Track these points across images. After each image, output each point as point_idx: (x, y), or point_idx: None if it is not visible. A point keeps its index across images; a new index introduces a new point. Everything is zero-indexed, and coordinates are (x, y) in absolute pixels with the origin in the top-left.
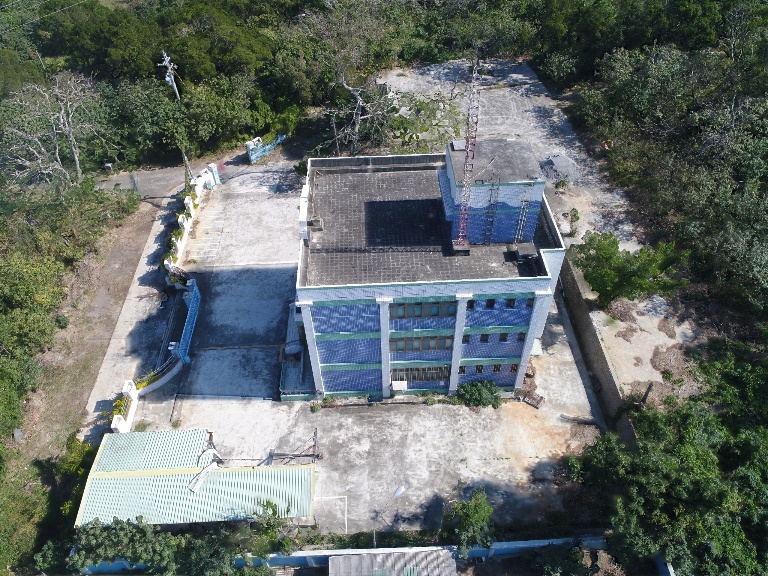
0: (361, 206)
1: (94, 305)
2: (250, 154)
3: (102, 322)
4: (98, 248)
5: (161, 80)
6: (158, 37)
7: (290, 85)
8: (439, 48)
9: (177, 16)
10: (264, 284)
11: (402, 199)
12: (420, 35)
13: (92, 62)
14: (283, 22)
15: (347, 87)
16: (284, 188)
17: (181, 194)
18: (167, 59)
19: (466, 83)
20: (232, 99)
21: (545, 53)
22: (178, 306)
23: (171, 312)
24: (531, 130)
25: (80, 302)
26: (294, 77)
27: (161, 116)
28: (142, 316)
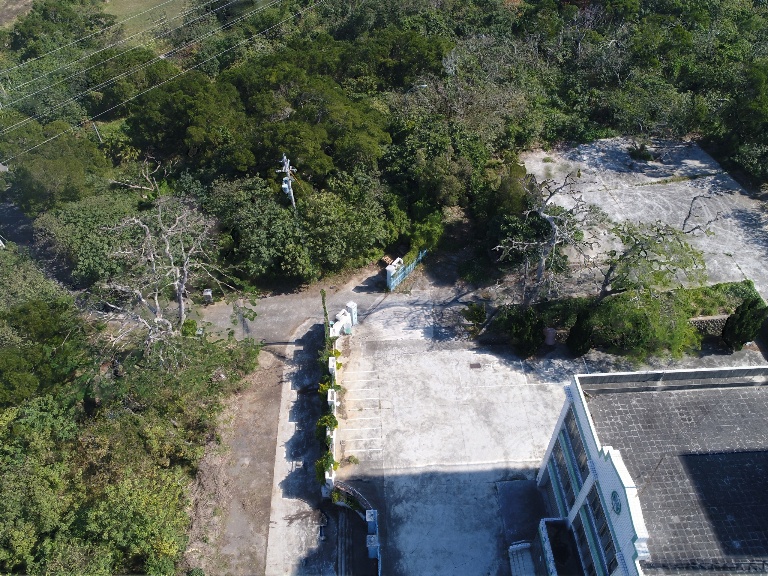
0: (677, 464)
1: (228, 533)
2: (390, 281)
3: (245, 565)
4: (220, 436)
5: (267, 179)
6: (236, 104)
7: (436, 190)
8: (585, 123)
9: (258, 78)
10: (460, 502)
11: (732, 449)
12: (555, 104)
13: (162, 137)
14: (395, 91)
15: (543, 215)
16: (444, 333)
17: (324, 355)
18: (286, 163)
19: (633, 173)
20: (365, 210)
21: (728, 135)
22: (348, 540)
23: (338, 548)
24: (743, 247)
25: (210, 530)
26: (444, 182)
27: (280, 236)
28: (298, 554)
